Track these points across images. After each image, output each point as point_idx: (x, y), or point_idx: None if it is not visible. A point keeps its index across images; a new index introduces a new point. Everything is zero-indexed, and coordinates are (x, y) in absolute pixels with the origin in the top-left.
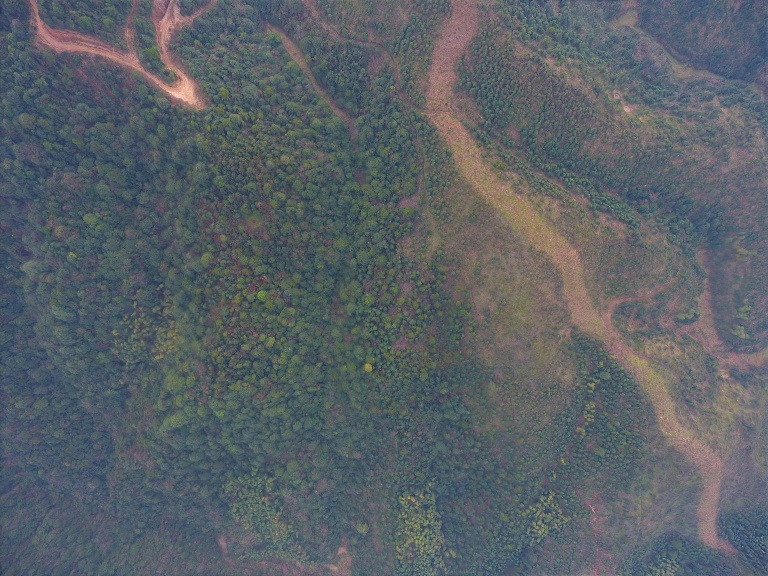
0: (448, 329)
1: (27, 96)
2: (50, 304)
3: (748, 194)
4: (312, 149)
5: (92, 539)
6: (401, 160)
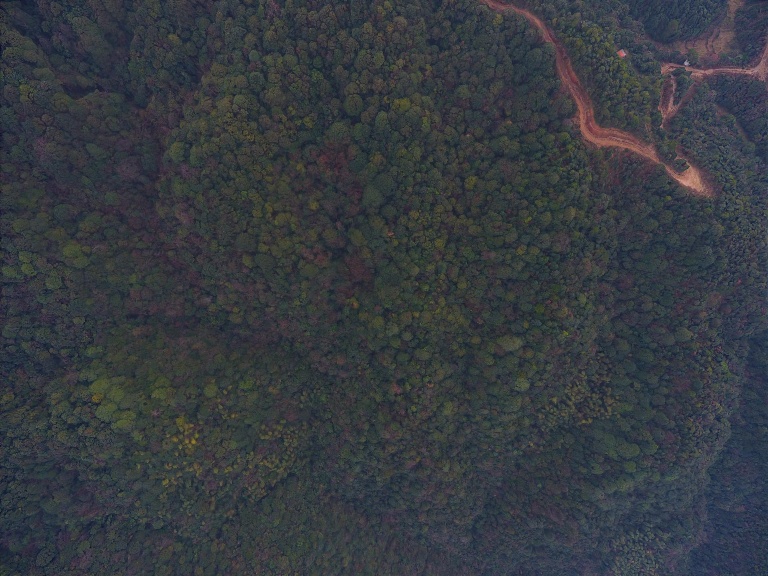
0: None
1: (580, 192)
2: (515, 377)
3: None
4: None
5: None
6: None
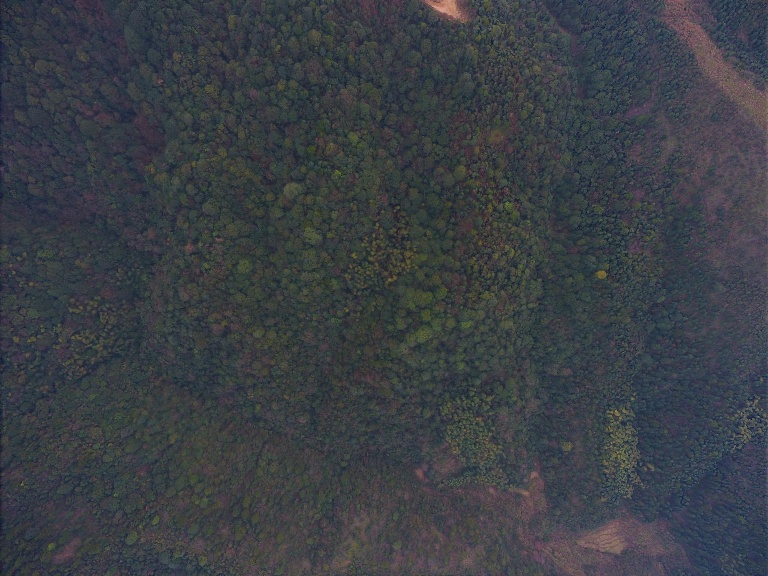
0: (673, 234)
1: (319, 12)
2: (303, 227)
3: None
4: None
5: (306, 471)
6: (633, 69)
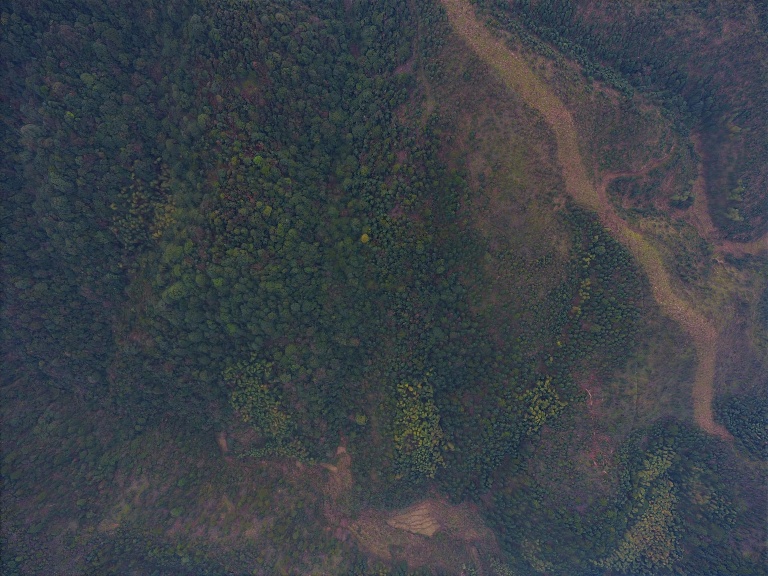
0: (444, 201)
1: None
2: (48, 172)
3: (741, 69)
4: (307, 13)
5: (93, 432)
6: (395, 25)
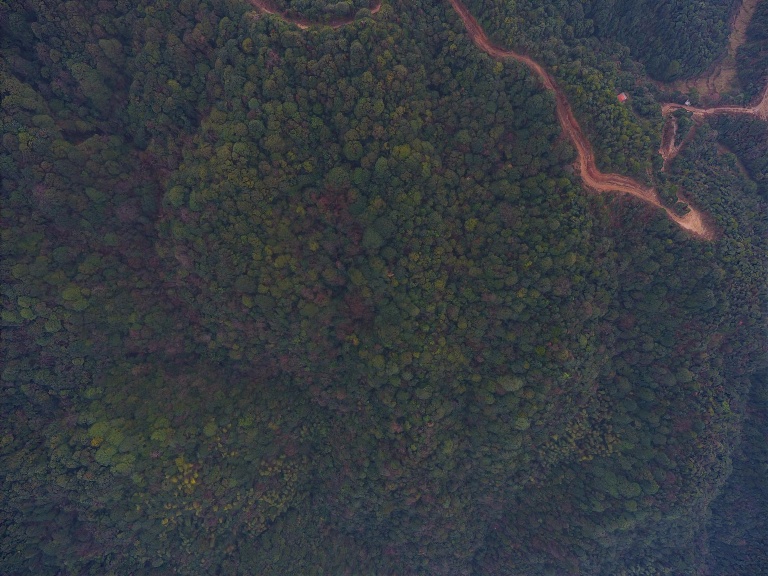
0: None
1: (580, 238)
2: (516, 416)
3: None
4: None
5: None
6: None
